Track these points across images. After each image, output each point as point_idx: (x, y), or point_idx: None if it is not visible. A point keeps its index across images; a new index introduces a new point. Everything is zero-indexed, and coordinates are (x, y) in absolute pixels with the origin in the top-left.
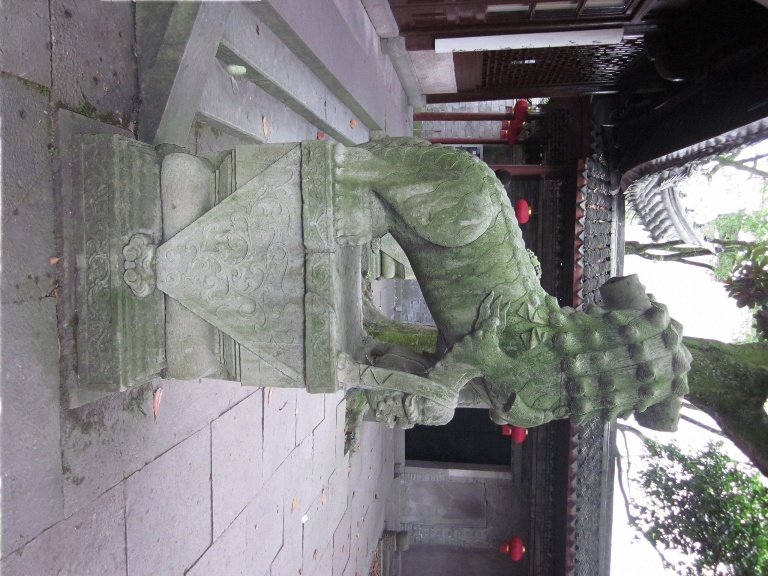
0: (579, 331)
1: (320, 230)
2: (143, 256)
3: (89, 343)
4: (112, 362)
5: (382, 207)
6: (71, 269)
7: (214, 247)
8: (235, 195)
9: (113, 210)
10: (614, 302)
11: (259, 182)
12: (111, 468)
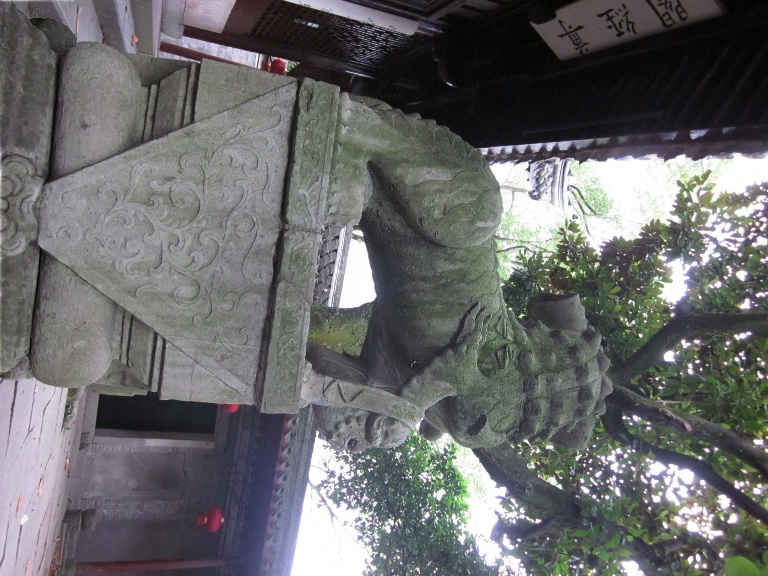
0: (538, 350)
1: (310, 202)
2: (24, 193)
3: None
4: None
5: (371, 184)
6: None
7: (146, 198)
8: (191, 129)
9: None
10: (554, 320)
11: (231, 119)
12: None
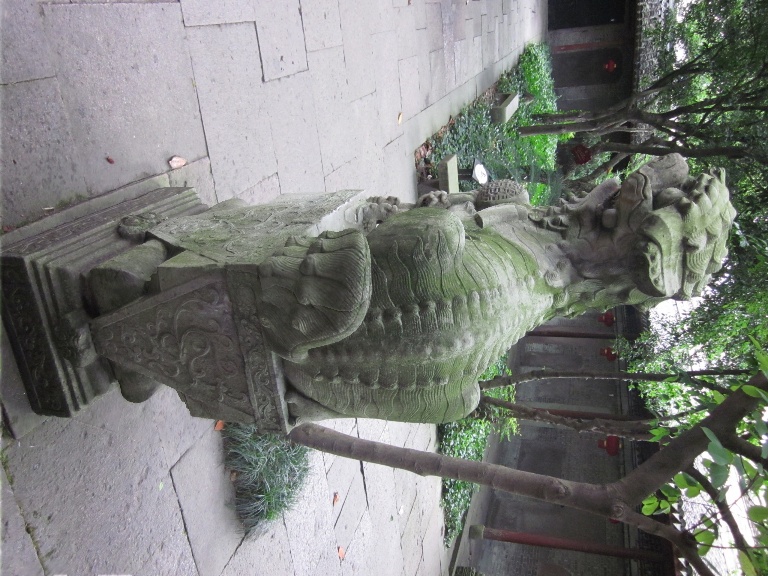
0: None
1: None
2: None
3: None
4: None
5: None
6: None
7: None
8: None
9: None
10: None
11: None
12: None
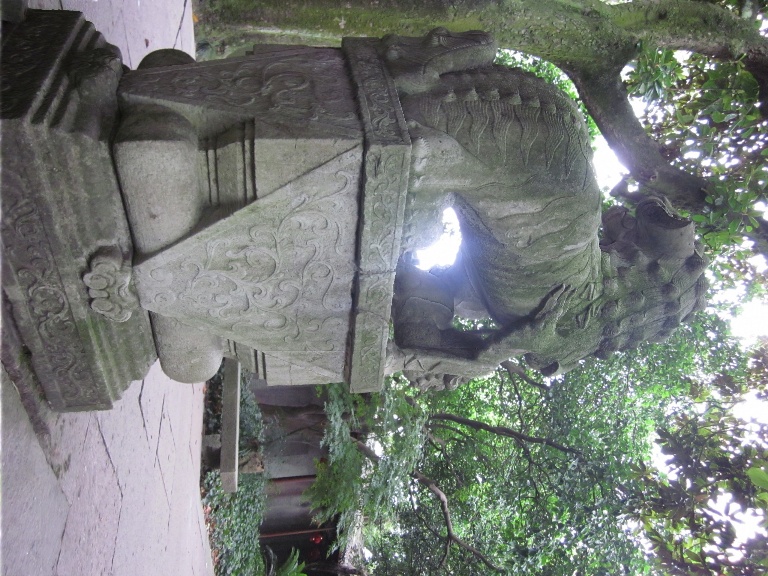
0: (627, 295)
1: (383, 252)
2: (118, 284)
3: (56, 373)
4: (95, 387)
5: (453, 197)
6: (1, 304)
7: (225, 264)
8: (255, 206)
9: (54, 233)
10: (658, 246)
11: (294, 191)
12: (82, 414)
